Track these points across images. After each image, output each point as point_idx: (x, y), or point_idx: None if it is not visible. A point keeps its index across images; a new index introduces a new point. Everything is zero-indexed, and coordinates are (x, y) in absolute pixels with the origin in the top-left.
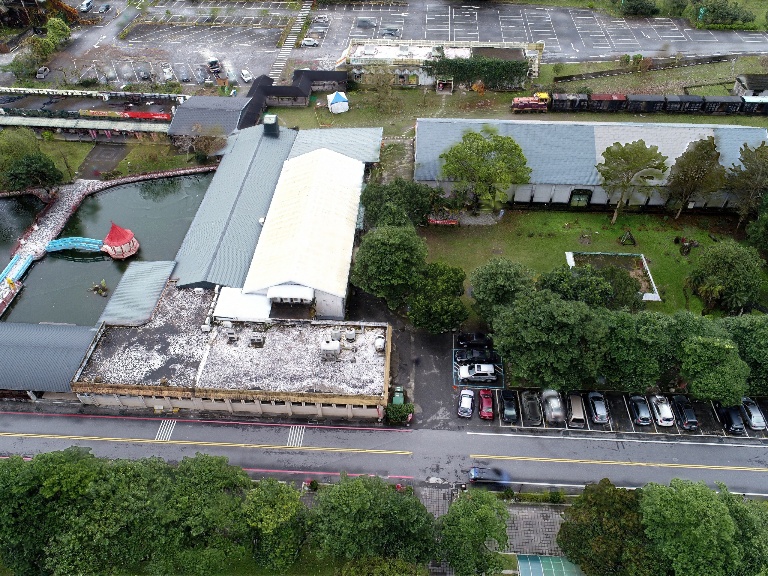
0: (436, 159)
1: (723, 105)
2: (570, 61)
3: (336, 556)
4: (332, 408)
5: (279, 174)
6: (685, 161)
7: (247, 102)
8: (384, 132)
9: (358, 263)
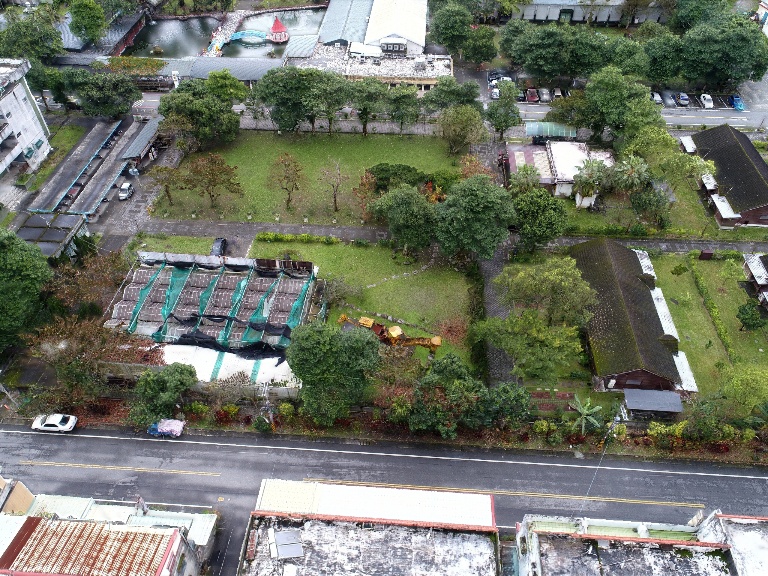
0: None
1: None
2: None
3: (431, 137)
4: (422, 91)
5: (372, 1)
6: None
7: None
8: None
9: (433, 26)
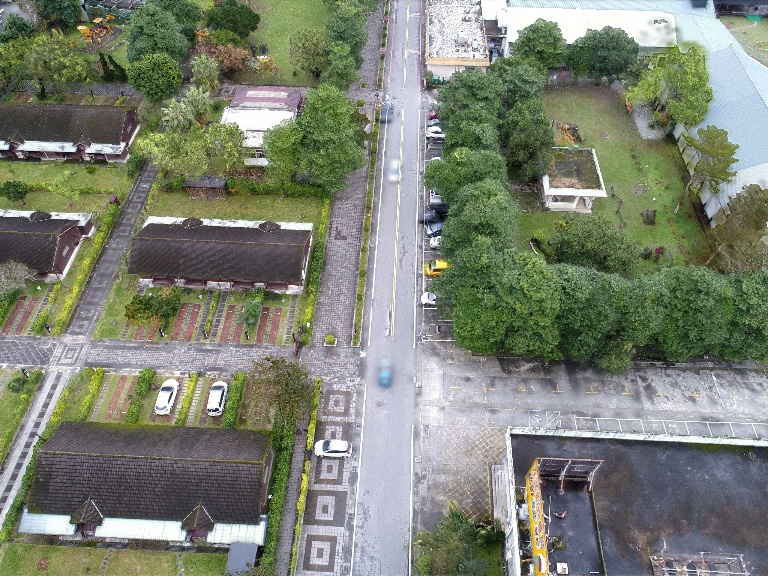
0: None
1: None
2: None
3: None
4: None
5: None
6: None
7: None
8: None
9: None
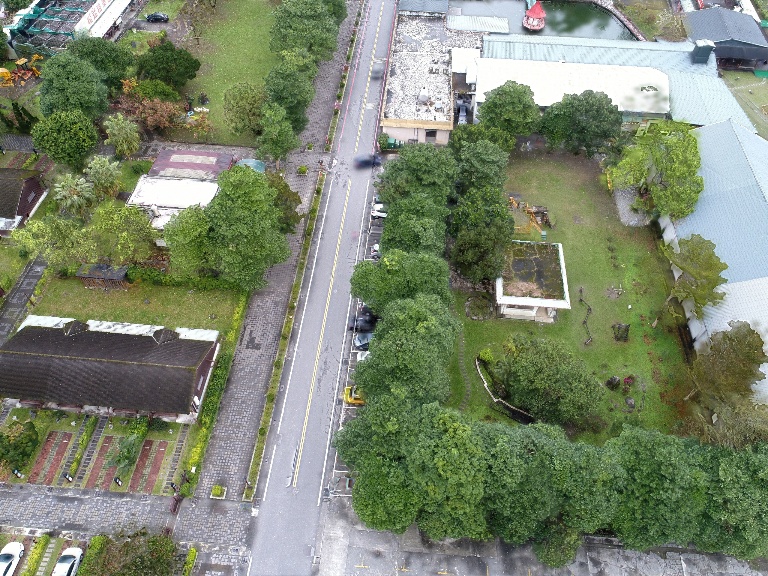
0: None
1: None
2: None
3: None
4: None
5: None
6: None
7: (755, 43)
8: None
9: None
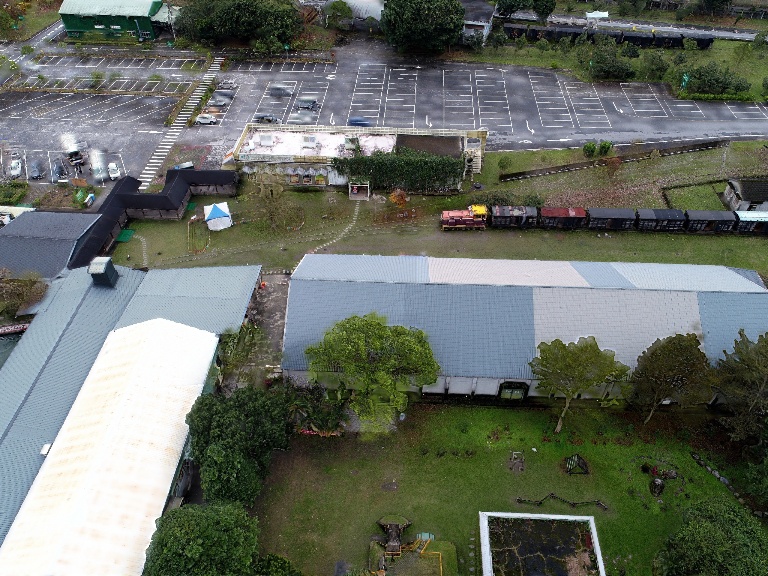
0: (313, 337)
1: (711, 224)
2: (522, 148)
3: None
4: None
5: None
6: (656, 362)
7: (91, 224)
8: (271, 262)
9: (145, 570)
